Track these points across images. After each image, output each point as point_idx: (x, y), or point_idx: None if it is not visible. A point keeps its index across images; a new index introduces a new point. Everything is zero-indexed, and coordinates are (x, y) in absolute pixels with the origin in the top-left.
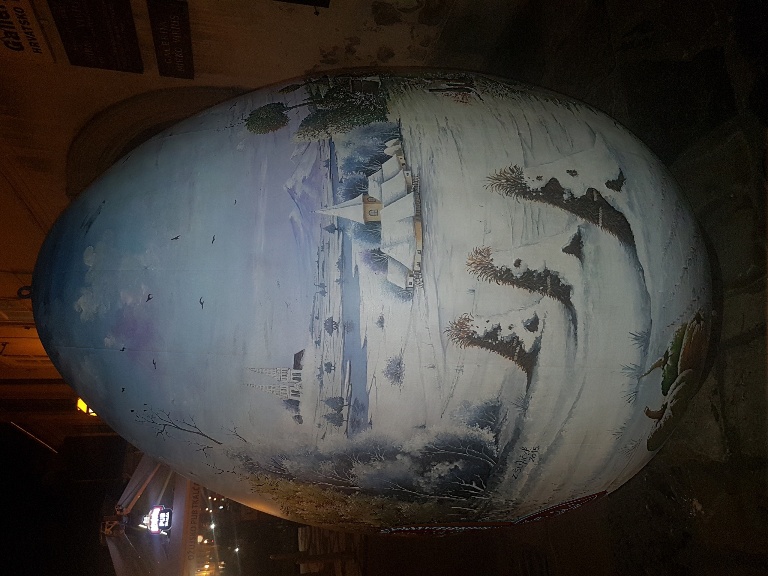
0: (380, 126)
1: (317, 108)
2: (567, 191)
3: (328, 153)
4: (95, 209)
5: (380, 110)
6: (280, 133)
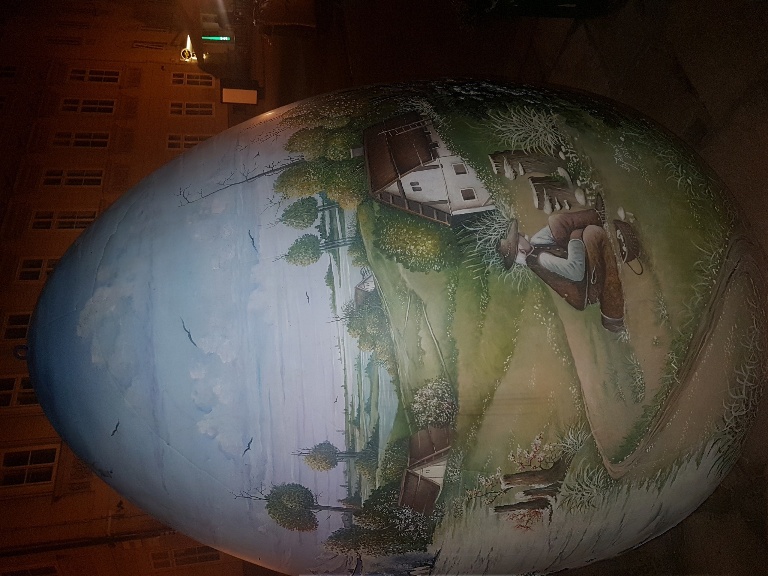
0: (415, 557)
1: (352, 522)
2: (571, 569)
3: (354, 566)
4: (103, 468)
5: (423, 540)
6: (306, 536)
